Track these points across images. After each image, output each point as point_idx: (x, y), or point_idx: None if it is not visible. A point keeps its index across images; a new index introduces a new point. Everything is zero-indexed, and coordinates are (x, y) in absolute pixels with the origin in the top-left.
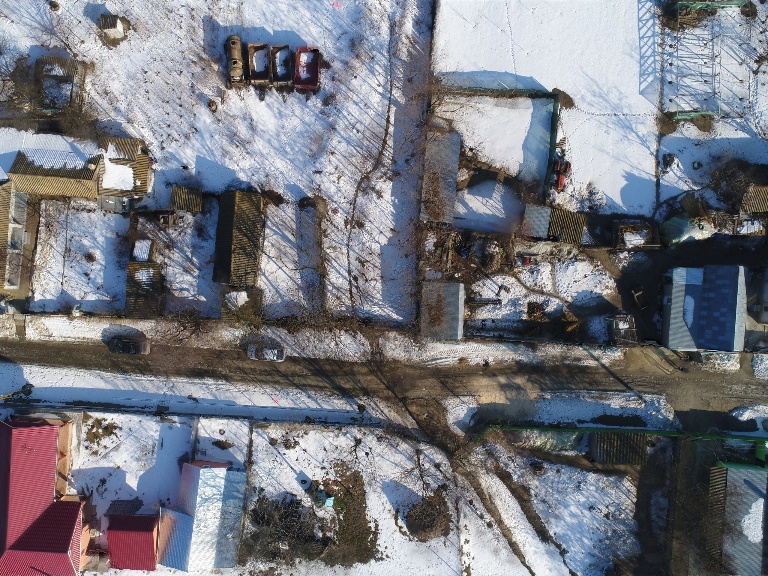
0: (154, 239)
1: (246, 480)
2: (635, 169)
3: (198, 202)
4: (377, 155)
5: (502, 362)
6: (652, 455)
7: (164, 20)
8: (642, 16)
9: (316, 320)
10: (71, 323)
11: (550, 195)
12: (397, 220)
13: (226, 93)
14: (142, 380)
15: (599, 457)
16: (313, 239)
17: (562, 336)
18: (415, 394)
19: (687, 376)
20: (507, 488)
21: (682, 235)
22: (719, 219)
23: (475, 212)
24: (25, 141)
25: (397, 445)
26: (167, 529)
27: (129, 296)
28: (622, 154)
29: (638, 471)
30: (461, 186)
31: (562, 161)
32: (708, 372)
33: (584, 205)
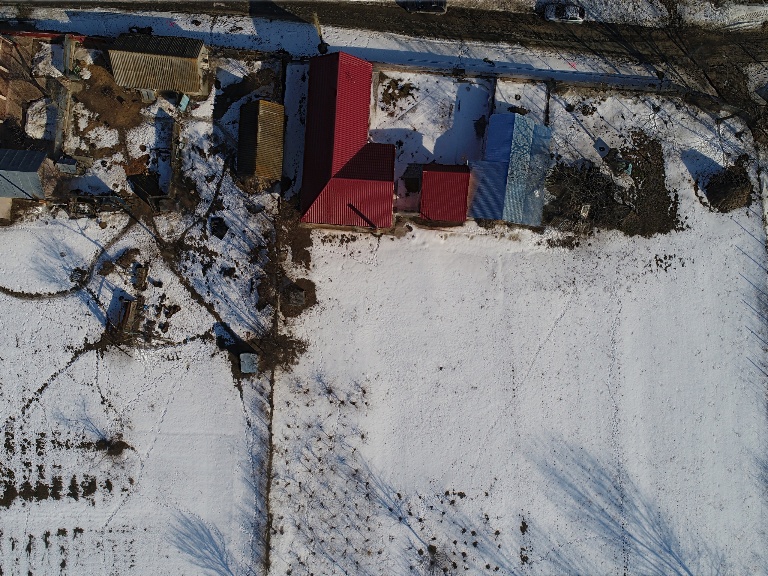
0: None
1: None
2: None
3: None
4: None
5: None
6: None
7: None
8: None
9: None
10: None
11: None
12: None
13: None
14: (436, 43)
15: None
16: None
17: None
18: (715, 61)
19: None
20: None
21: None
22: None
23: None
24: None
25: (696, 114)
26: (476, 180)
27: None
28: None
29: None
30: None
31: None
32: None
33: None
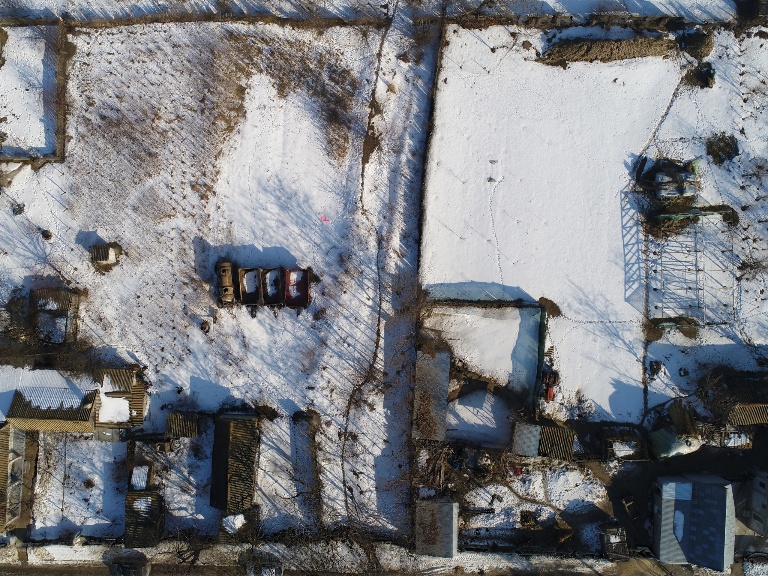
0: (151, 460)
1: None
2: (623, 376)
3: (193, 428)
4: (368, 368)
5: (497, 570)
6: None
7: (155, 244)
8: (626, 223)
9: (313, 534)
10: (72, 548)
11: (540, 406)
12: (390, 431)
13: (218, 312)
14: None
15: None
16: (308, 452)
17: (555, 544)
18: None
19: None
20: None
21: (670, 451)
22: (706, 431)
23: (466, 423)
24: (22, 379)
25: None
26: None
27: (128, 526)
28: (609, 361)
29: None
30: (452, 396)
31: (550, 372)
32: None
33: (573, 413)
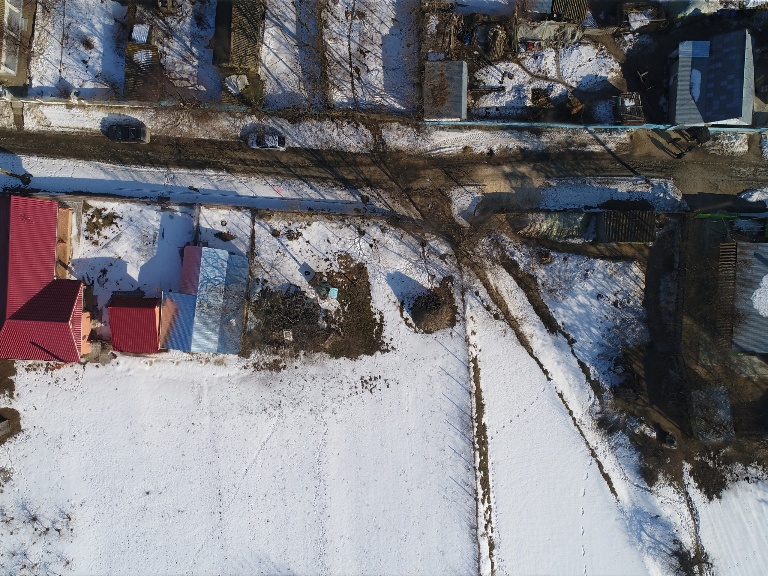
0: (153, 28)
1: (249, 270)
2: None
3: None
4: None
5: (507, 150)
6: (660, 239)
7: None
8: None
9: (318, 109)
10: (70, 111)
11: None
12: (398, 10)
13: None
14: (142, 171)
15: (607, 235)
16: (313, 30)
17: (567, 122)
18: (419, 185)
19: (694, 159)
20: (513, 279)
21: (688, 8)
22: None
23: None
24: None
25: (401, 237)
26: (169, 312)
27: (128, 77)
28: None
29: (646, 257)
30: None
31: None
32: (716, 155)
33: None
